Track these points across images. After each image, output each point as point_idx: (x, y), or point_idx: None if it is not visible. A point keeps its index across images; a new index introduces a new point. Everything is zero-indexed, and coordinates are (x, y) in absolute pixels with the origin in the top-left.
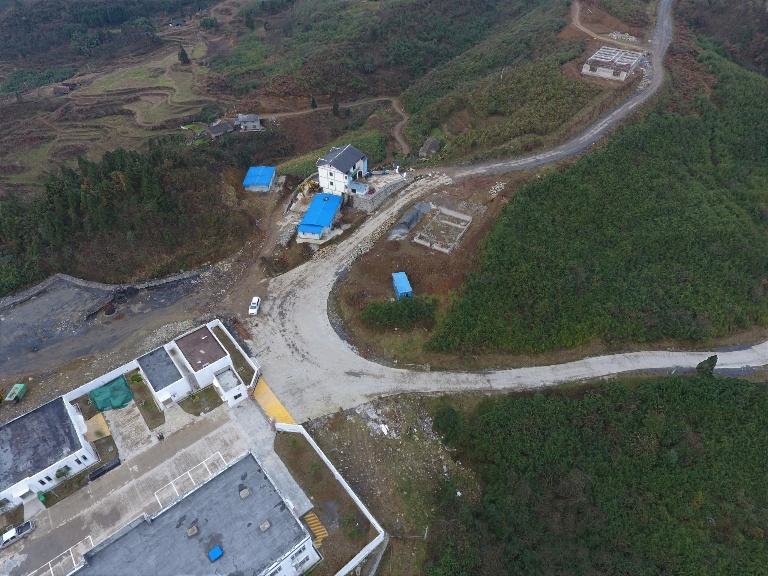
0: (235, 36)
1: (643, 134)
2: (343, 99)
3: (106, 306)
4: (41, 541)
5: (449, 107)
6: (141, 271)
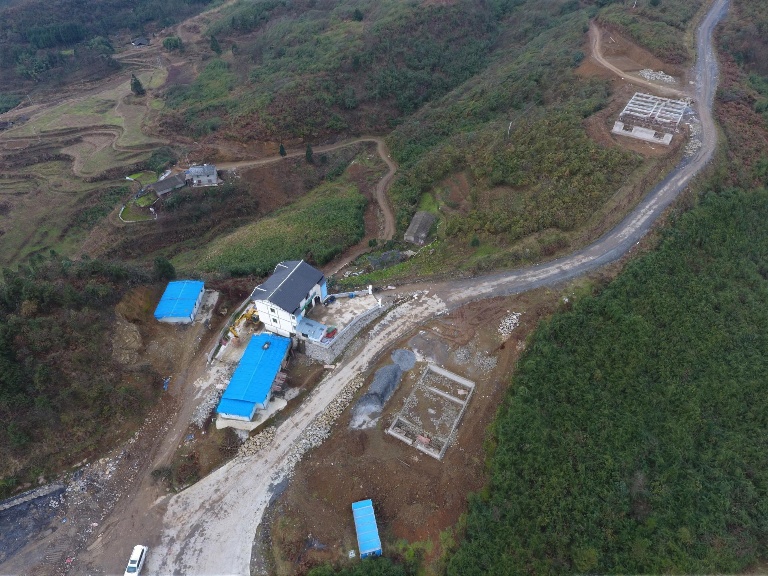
0: (200, 60)
1: (700, 224)
2: (319, 142)
3: None
4: None
5: (443, 168)
6: None
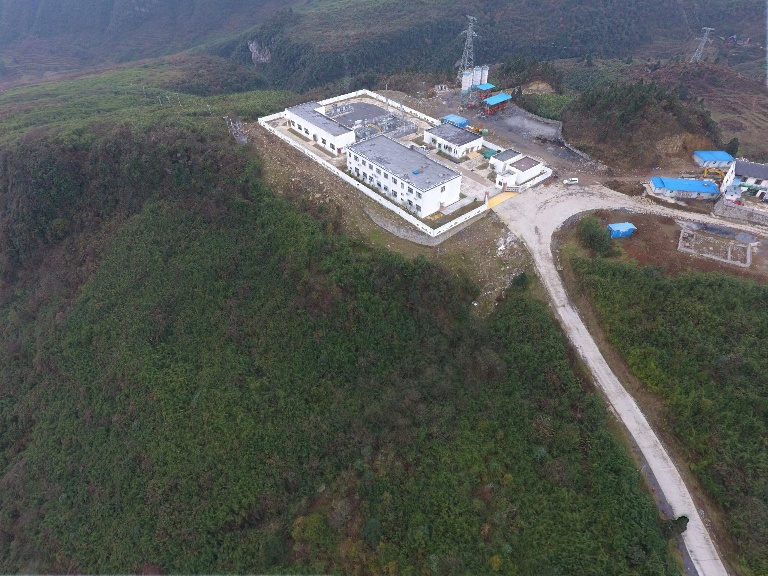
0: None
1: None
2: None
3: (545, 138)
4: None
5: None
6: (577, 141)
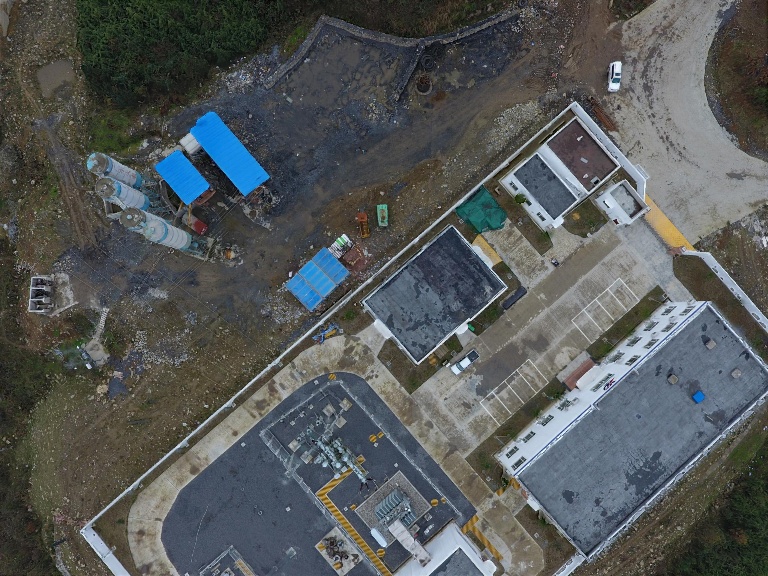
0: None
1: None
2: None
3: (422, 80)
4: (488, 364)
5: None
6: (442, 11)
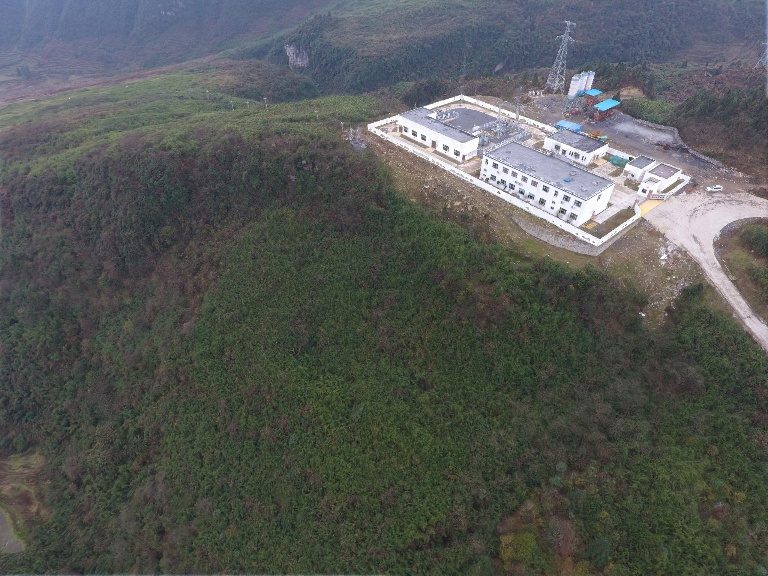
0: None
1: None
2: None
3: (667, 145)
4: None
5: None
6: (703, 147)
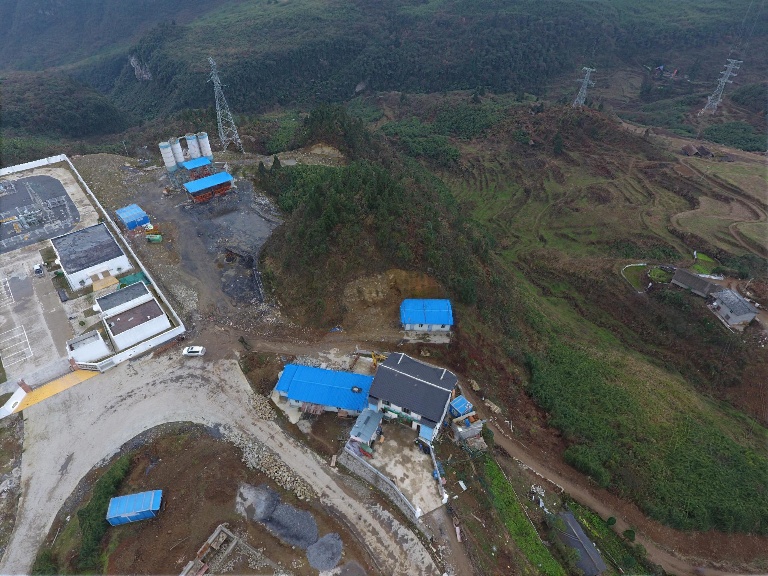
0: None
1: None
2: None
3: (230, 254)
4: (28, 283)
5: None
6: (271, 262)
